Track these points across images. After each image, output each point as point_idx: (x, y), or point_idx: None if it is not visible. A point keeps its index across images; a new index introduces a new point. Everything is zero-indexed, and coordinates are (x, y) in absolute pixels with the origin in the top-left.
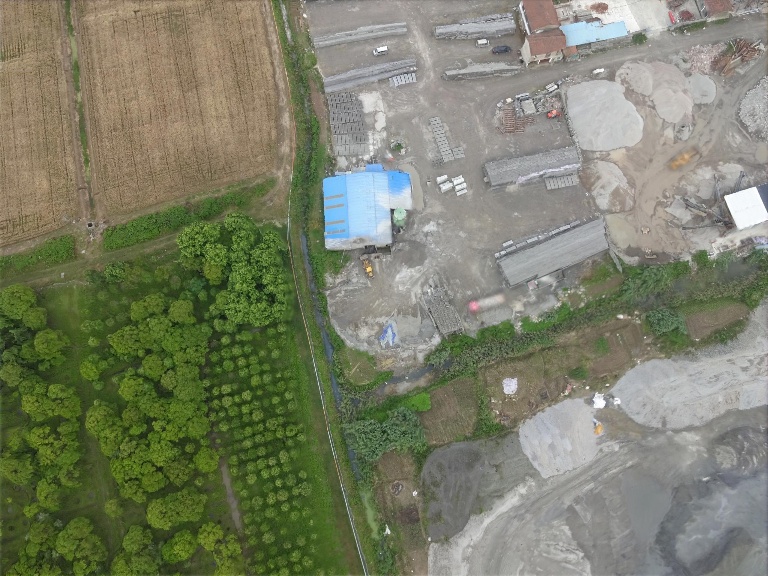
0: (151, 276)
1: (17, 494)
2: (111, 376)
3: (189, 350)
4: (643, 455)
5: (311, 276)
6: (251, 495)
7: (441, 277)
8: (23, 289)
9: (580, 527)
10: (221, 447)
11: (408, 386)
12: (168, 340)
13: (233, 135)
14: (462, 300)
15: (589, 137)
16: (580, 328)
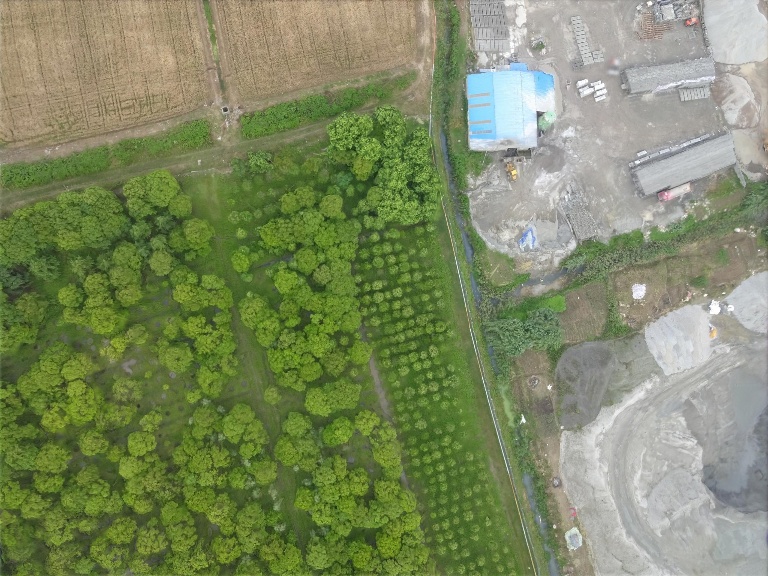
0: (298, 168)
1: (173, 381)
2: (257, 269)
3: (344, 245)
4: (749, 357)
5: (451, 176)
6: (402, 386)
7: (578, 184)
8: (169, 175)
9: (696, 418)
10: (373, 341)
11: (543, 288)
12: (323, 235)
13: (370, 20)
14: (596, 207)
15: (724, 49)
16: (702, 239)
